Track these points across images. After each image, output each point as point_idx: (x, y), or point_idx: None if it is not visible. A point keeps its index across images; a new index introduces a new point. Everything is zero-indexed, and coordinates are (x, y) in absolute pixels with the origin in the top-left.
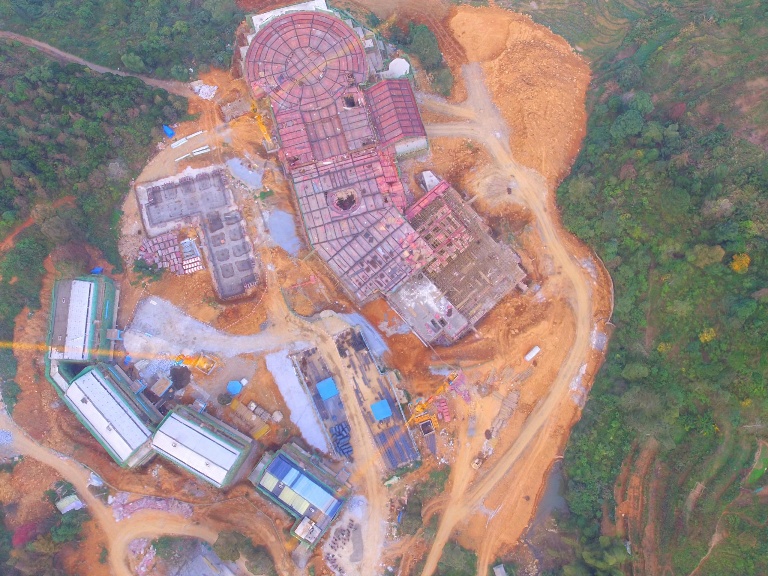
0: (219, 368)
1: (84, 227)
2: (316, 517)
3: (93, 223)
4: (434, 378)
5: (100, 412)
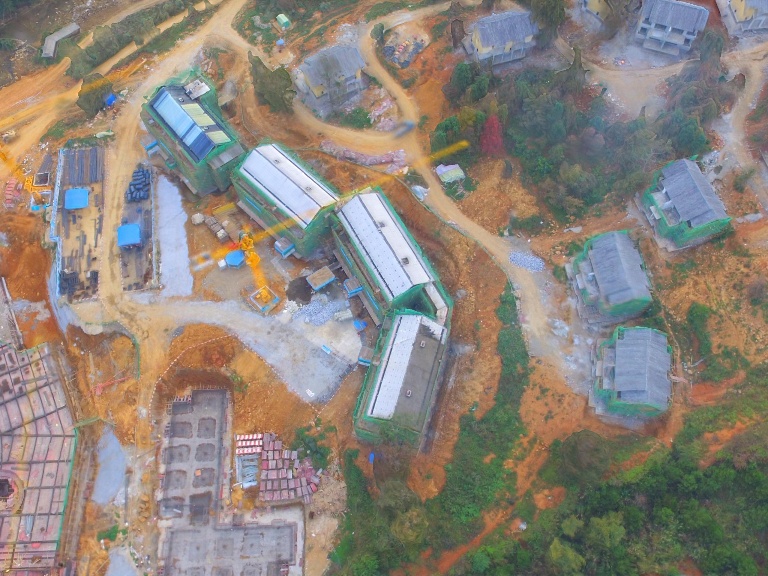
0: (251, 290)
1: (384, 533)
2: (182, 96)
3: (372, 539)
4: (5, 228)
5: (389, 244)
